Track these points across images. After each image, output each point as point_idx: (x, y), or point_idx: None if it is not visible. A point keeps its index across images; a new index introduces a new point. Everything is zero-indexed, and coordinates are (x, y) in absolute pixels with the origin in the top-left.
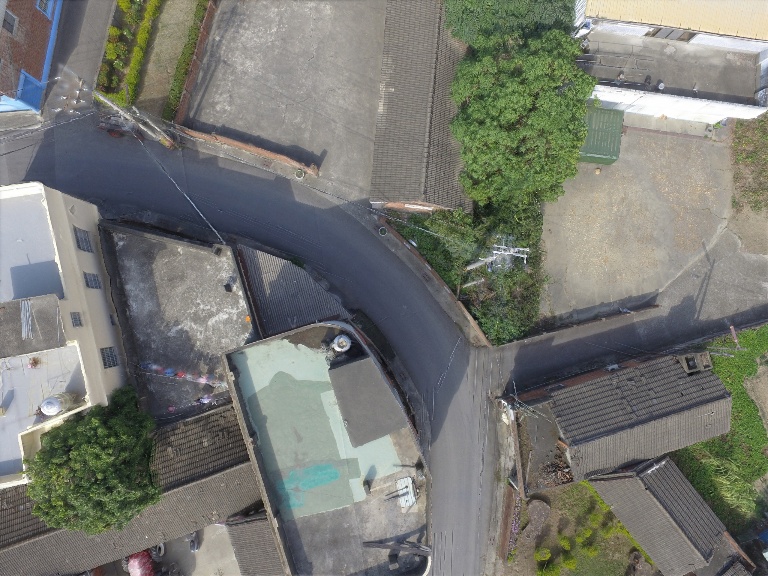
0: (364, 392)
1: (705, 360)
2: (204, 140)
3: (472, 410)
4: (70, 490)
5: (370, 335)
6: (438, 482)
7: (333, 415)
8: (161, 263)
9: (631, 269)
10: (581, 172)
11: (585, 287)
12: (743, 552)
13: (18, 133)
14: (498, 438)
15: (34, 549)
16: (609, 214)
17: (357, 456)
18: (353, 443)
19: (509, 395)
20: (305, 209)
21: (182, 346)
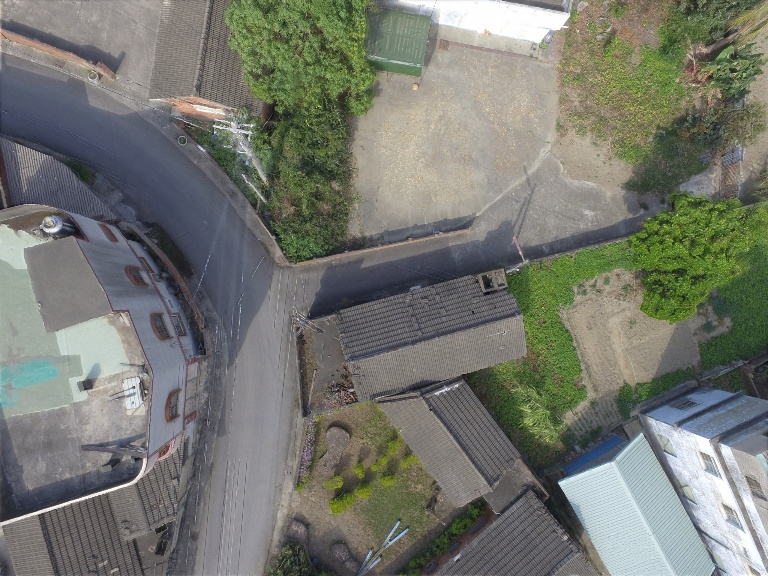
0: (62, 273)
1: (500, 278)
2: None
3: (273, 333)
4: None
5: (166, 251)
6: (234, 407)
7: None
8: None
9: (447, 191)
10: (398, 87)
11: (398, 208)
12: (536, 480)
13: None
14: None
15: None
16: (426, 132)
17: (80, 353)
18: (47, 328)
19: (313, 318)
20: (100, 114)
21: None
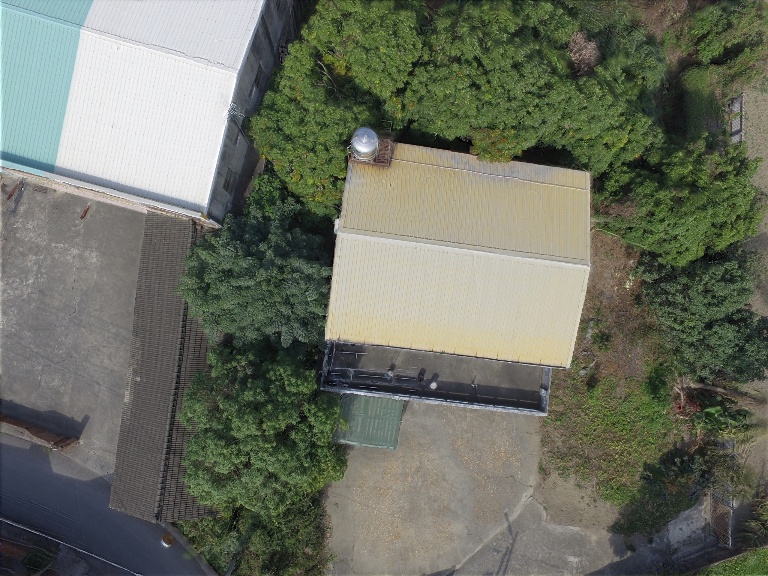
0: None
1: None
2: None
3: None
4: None
5: None
6: None
7: None
8: None
9: (425, 545)
10: None
11: (374, 566)
12: None
13: None
14: None
15: None
16: (402, 486)
17: None
18: None
19: None
20: (64, 481)
21: None
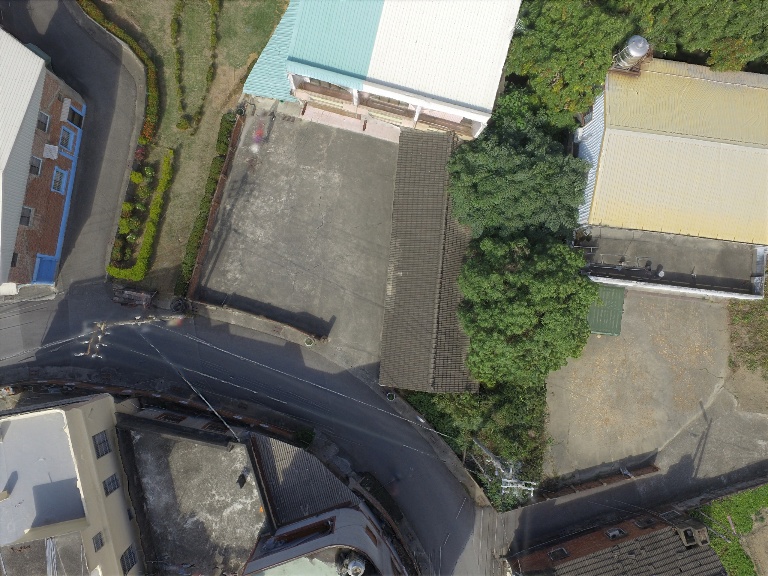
0: None
1: (703, 536)
2: (215, 308)
3: (478, 569)
4: None
5: (378, 497)
6: None
7: None
8: (177, 456)
9: (631, 429)
10: None
11: (587, 448)
12: None
13: (33, 304)
14: None
15: None
16: (610, 376)
17: None
18: None
19: (513, 554)
20: (315, 374)
21: (198, 537)
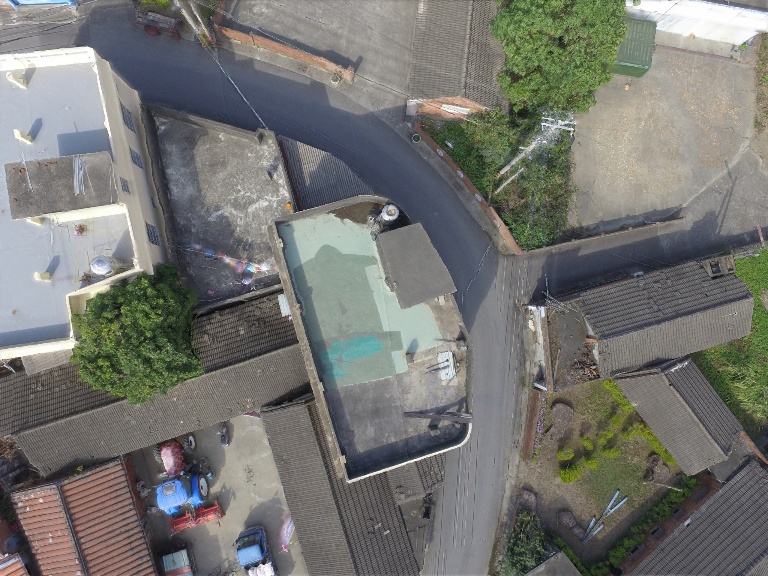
0: (413, 256)
1: (729, 264)
2: (240, 42)
3: (499, 316)
4: (121, 344)
5: None
6: None
7: (377, 289)
8: (202, 149)
9: (656, 183)
10: (611, 87)
11: (612, 199)
12: (759, 451)
13: None
14: (524, 344)
15: (71, 428)
16: (637, 129)
17: (400, 329)
18: (402, 304)
19: (536, 302)
20: (339, 114)
21: (222, 231)
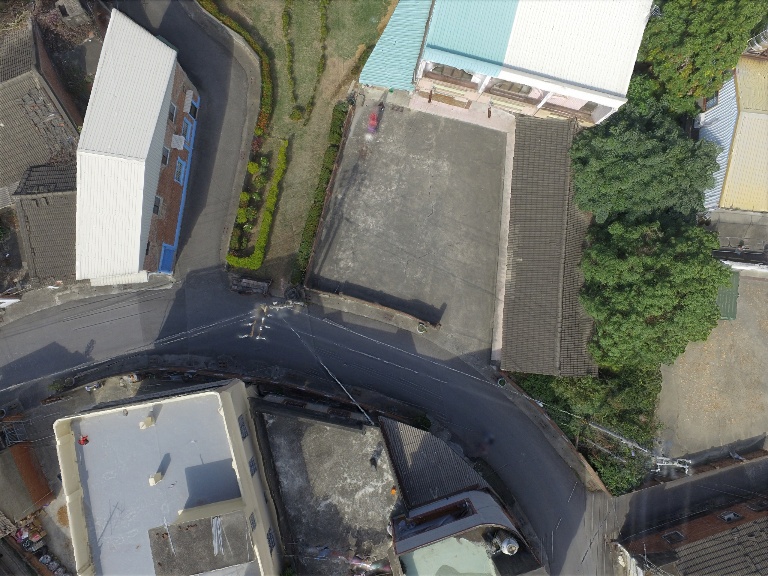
0: None
1: None
2: (328, 296)
3: (589, 553)
4: None
5: (490, 482)
6: None
7: None
8: (309, 439)
9: (740, 414)
10: None
11: (696, 432)
12: None
13: (151, 293)
14: None
15: None
16: (718, 361)
17: None
18: None
19: (625, 538)
20: (426, 361)
21: (331, 520)
